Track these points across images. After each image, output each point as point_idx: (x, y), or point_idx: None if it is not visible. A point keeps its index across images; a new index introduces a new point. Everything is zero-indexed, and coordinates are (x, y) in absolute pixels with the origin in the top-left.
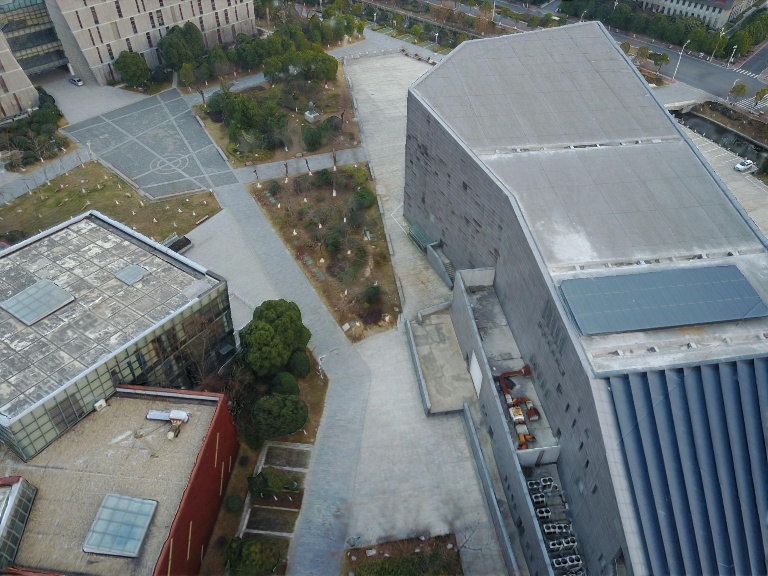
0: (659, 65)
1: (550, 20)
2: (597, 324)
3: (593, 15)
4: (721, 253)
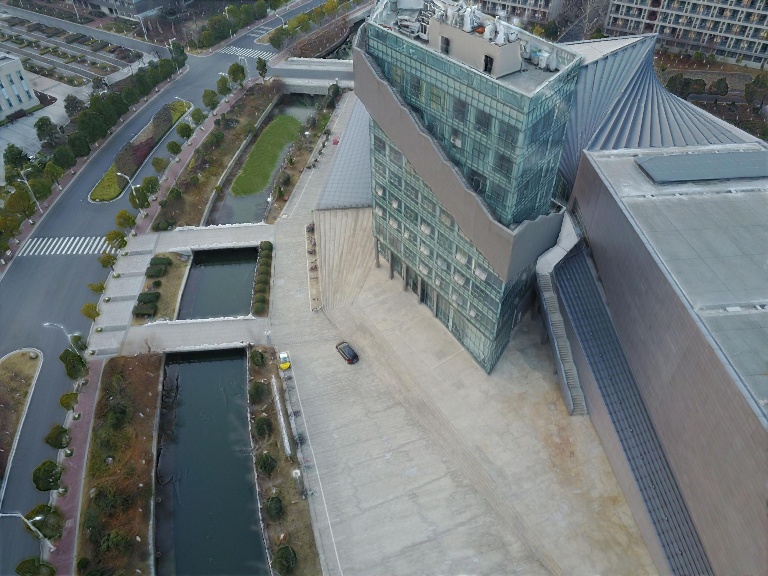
0: None
1: None
2: (766, 153)
3: None
4: None
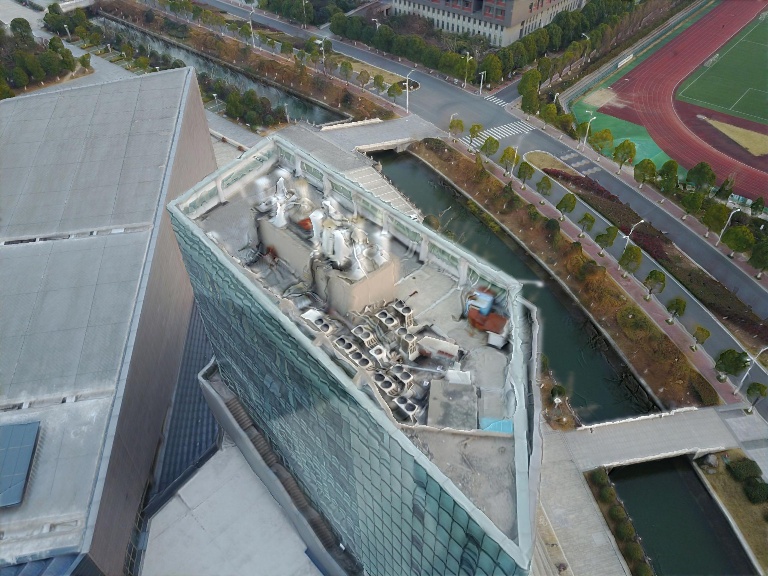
0: (393, 96)
1: (311, 44)
2: None
3: (360, 37)
4: (53, 399)
